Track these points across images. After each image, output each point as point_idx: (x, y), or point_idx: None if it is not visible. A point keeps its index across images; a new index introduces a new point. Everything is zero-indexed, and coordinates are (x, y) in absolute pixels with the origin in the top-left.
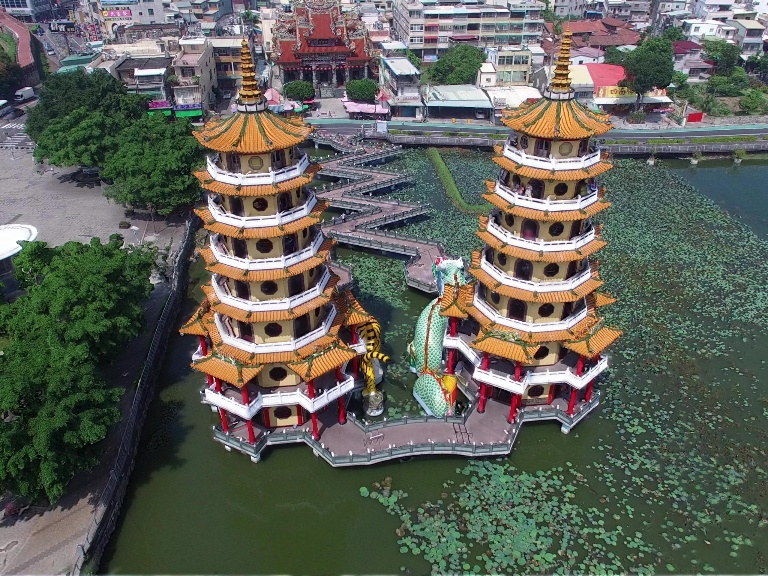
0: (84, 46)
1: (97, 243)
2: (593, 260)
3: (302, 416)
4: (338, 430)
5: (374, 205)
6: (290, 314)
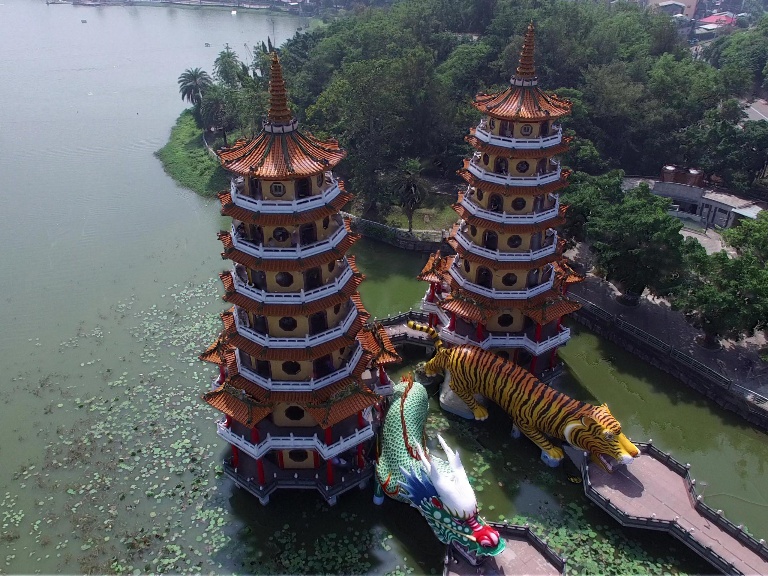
0: None
1: None
2: (232, 334)
3: None
4: None
5: None
6: None
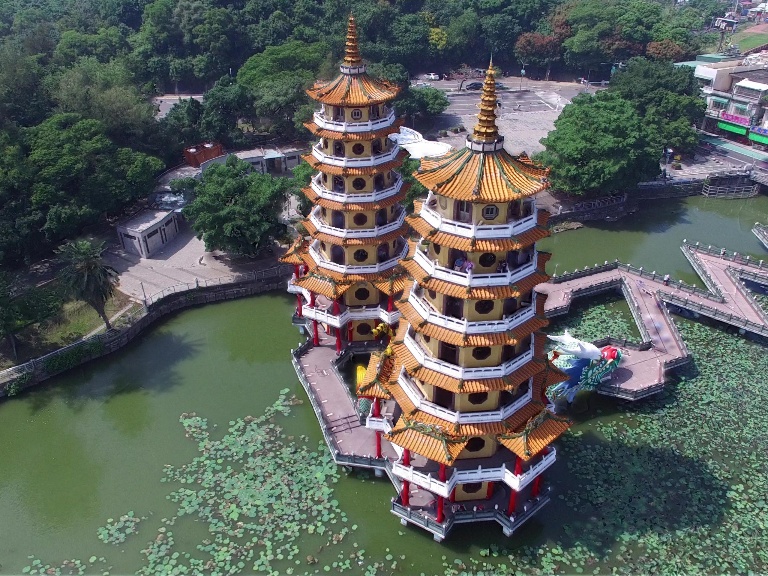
0: (728, 46)
1: (403, 162)
2: (507, 380)
3: (330, 328)
4: (330, 354)
5: (732, 294)
6: (314, 233)
